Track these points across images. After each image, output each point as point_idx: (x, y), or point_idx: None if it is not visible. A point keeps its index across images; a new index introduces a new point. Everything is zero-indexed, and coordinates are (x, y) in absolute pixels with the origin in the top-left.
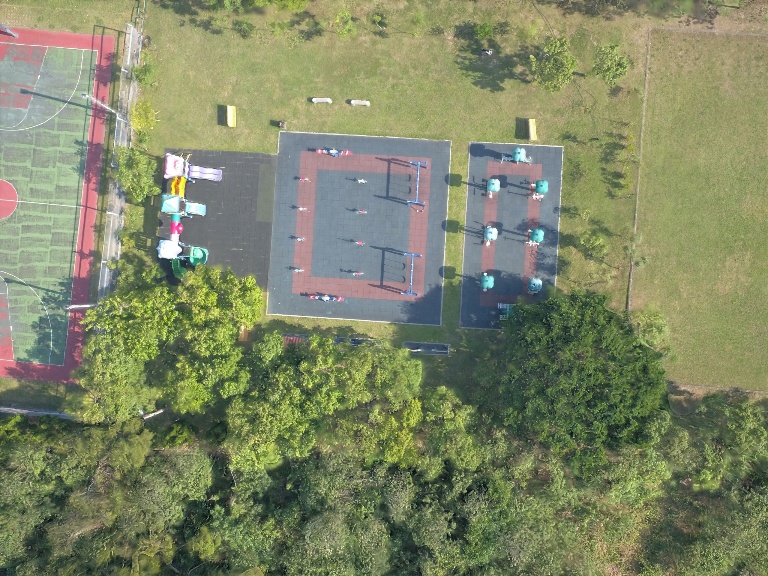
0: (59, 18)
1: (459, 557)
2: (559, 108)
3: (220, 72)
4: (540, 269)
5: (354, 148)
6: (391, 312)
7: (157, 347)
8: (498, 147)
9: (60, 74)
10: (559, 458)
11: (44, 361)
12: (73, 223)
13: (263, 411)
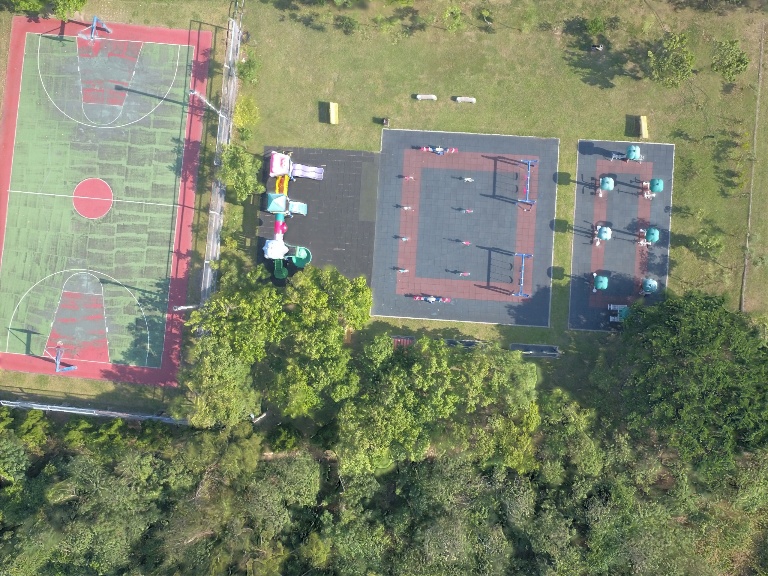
0: (154, 13)
1: (579, 564)
2: (670, 105)
3: (321, 68)
4: (651, 269)
5: (459, 146)
6: (498, 313)
7: (264, 349)
8: (607, 145)
9: (156, 70)
10: (686, 463)
11: (141, 363)
12: (170, 222)
13: (378, 415)
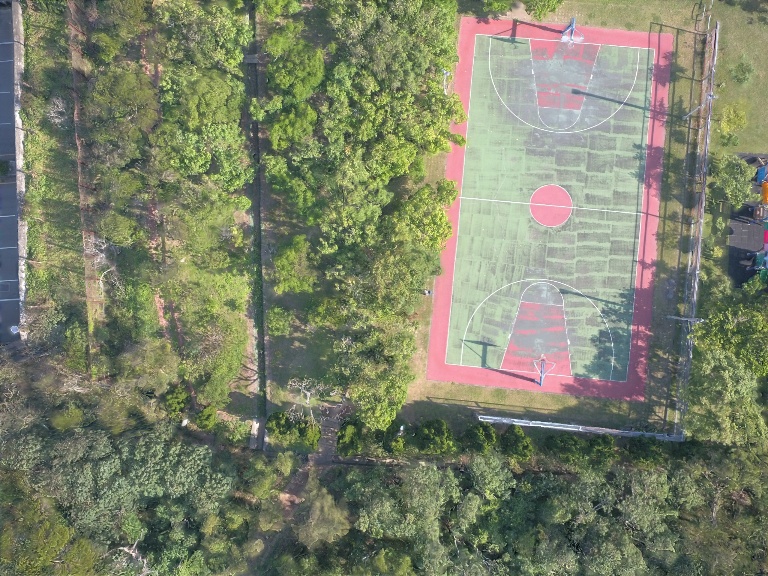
0: (612, 15)
1: None
2: None
3: None
4: None
5: None
6: None
7: None
8: None
9: (615, 74)
10: None
11: (605, 377)
12: (633, 231)
13: None
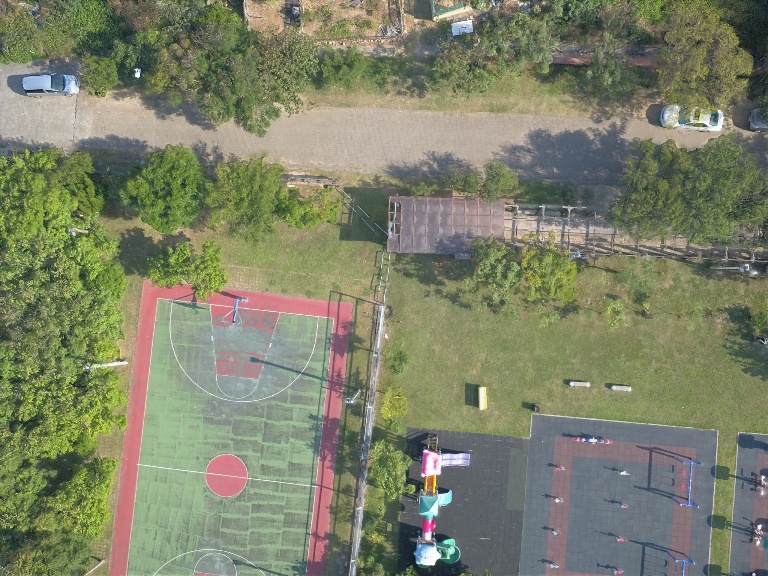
0: (292, 282)
1: None
2: None
3: (468, 348)
4: None
5: (613, 435)
6: None
7: None
8: None
9: (293, 343)
10: None
11: None
12: (307, 503)
13: None
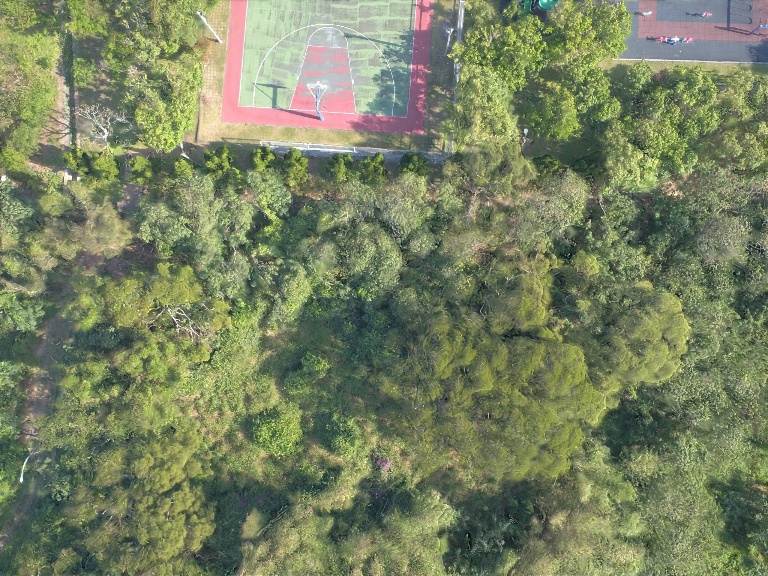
0: None
1: None
2: None
3: None
4: None
5: None
6: (739, 53)
7: (525, 78)
8: None
9: None
10: None
11: (387, 113)
12: None
13: (650, 126)
